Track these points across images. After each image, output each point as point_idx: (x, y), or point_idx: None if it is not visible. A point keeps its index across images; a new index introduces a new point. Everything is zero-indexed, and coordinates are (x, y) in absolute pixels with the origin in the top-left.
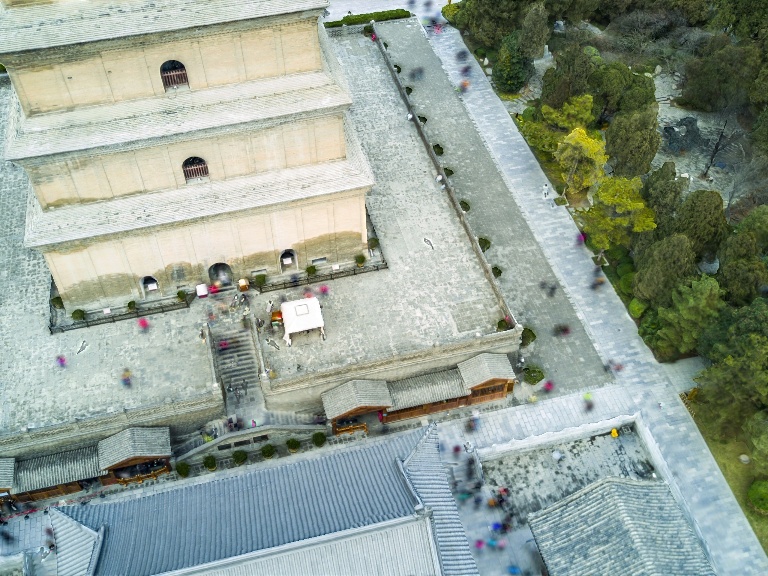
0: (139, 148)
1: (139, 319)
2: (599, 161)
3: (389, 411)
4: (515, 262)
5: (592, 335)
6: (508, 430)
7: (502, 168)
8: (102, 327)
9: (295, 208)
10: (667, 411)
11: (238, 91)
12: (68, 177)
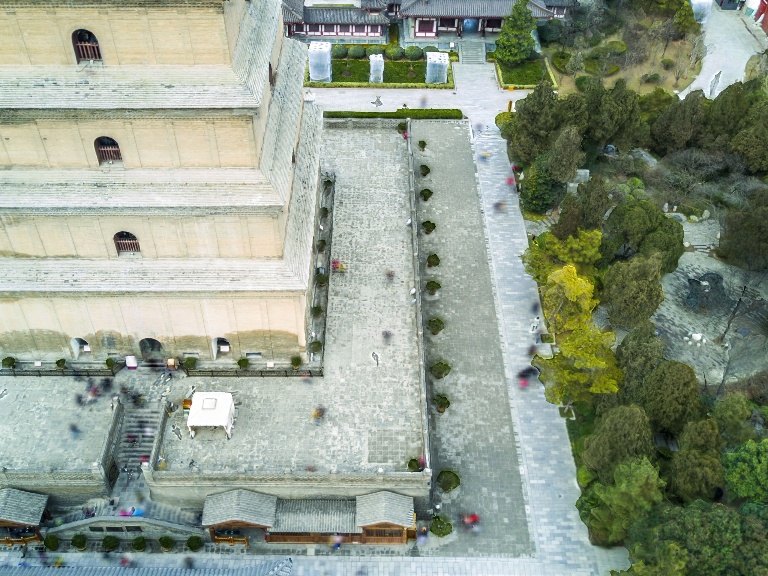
0: (69, 215)
1: (64, 378)
2: (583, 305)
3: (270, 531)
4: (473, 395)
5: (528, 495)
6: None
7: (498, 291)
8: (27, 379)
9: (226, 299)
10: None
11: (171, 175)
12: (2, 231)
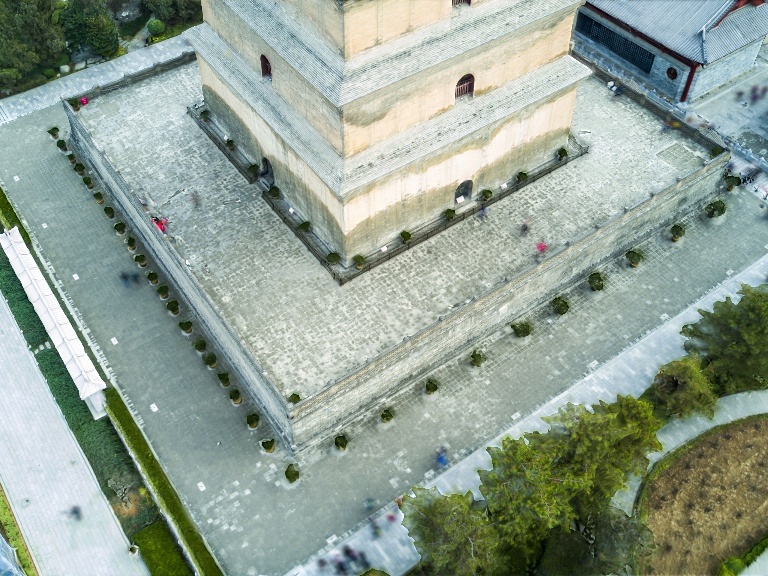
0: None
1: None
2: None
3: None
4: None
5: None
6: None
7: None
8: None
9: None
10: None
11: None
12: None
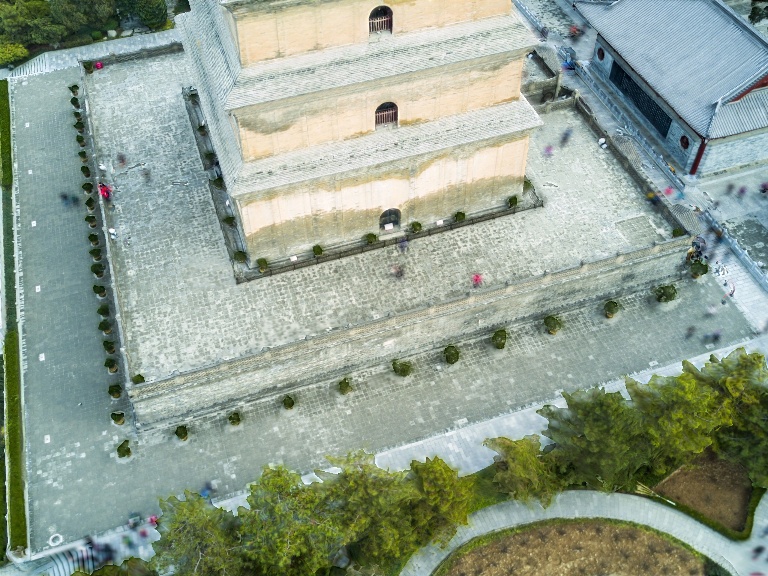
0: None
1: None
2: None
3: None
4: None
5: None
6: None
7: None
8: None
9: None
10: None
11: None
12: None
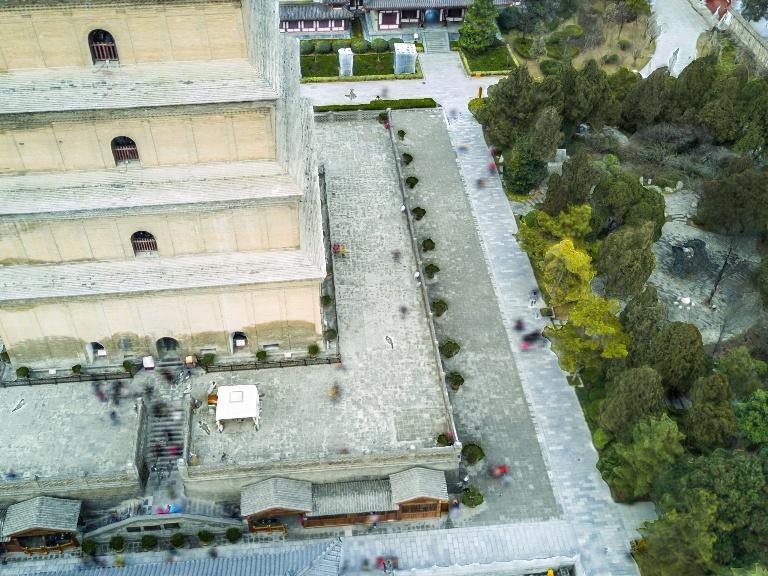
0: (86, 217)
1: (81, 384)
2: (583, 276)
3: (308, 516)
4: (484, 371)
5: (548, 461)
6: (434, 554)
7: (493, 270)
8: (44, 387)
9: (244, 292)
10: (612, 558)
11: (189, 172)
12: (17, 238)
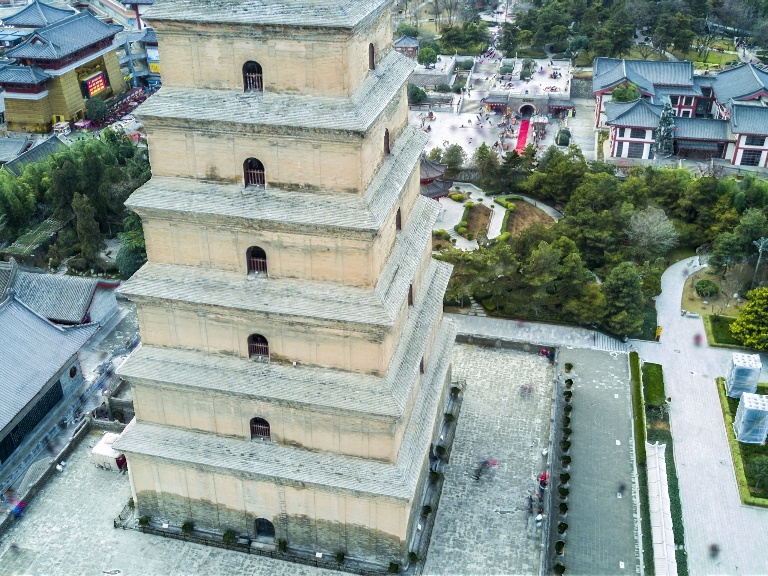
0: None
1: None
2: None
3: None
4: None
5: None
6: None
7: None
8: None
9: None
10: None
11: None
12: None
